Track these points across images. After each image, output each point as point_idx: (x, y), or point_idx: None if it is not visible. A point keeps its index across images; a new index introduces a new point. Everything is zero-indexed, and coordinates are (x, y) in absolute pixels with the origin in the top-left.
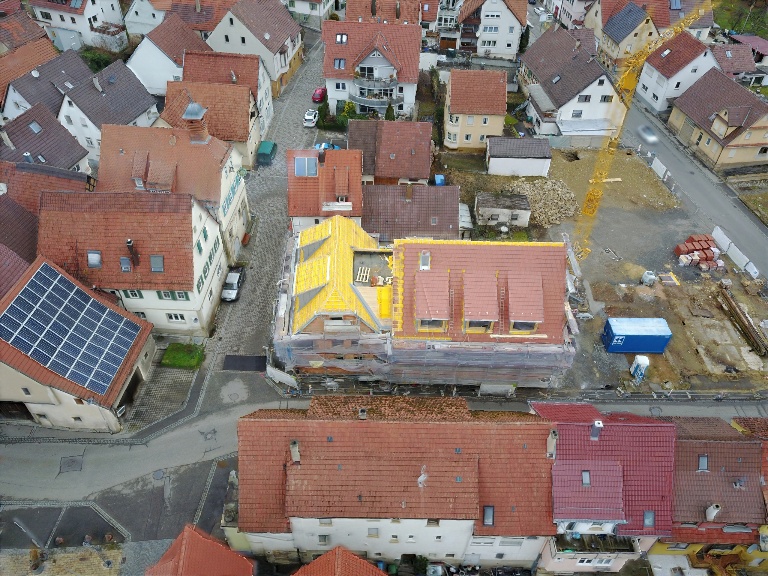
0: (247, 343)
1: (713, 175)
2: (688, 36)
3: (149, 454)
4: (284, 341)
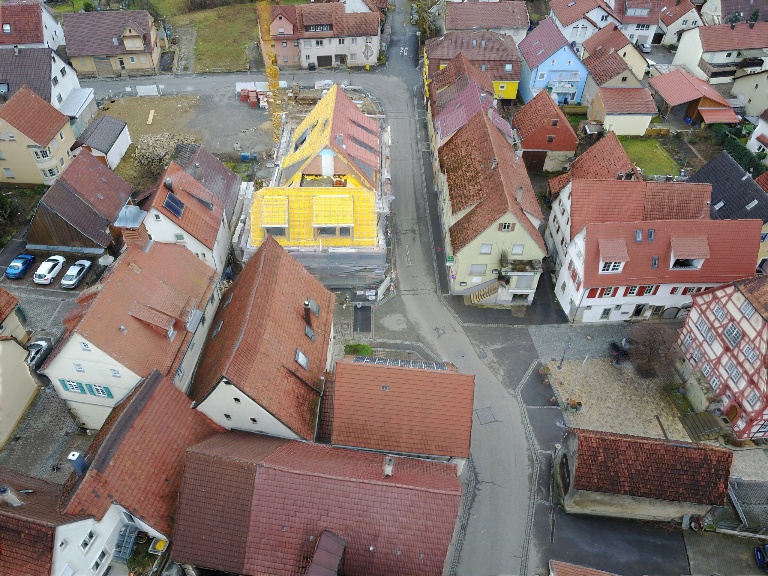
0: (339, 319)
1: (163, 75)
2: (6, 6)
3: (465, 365)
4: (385, 248)
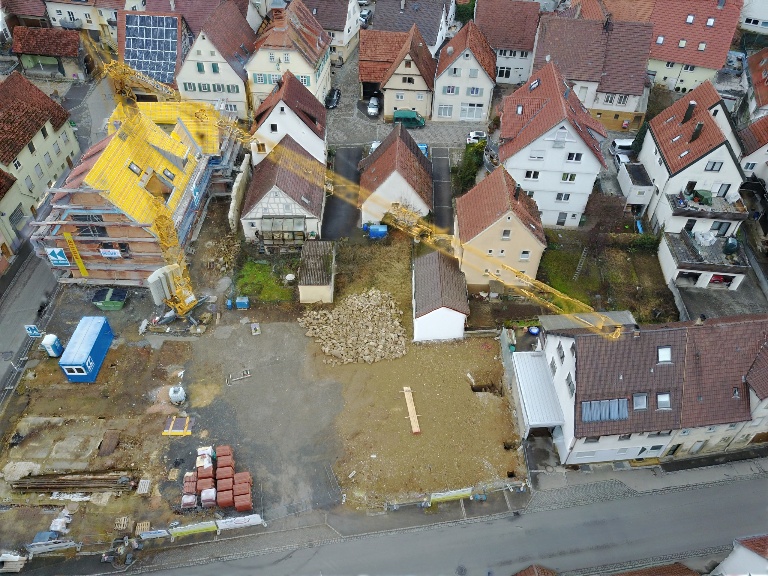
0: None
1: None
2: None
3: (104, 117)
4: None
